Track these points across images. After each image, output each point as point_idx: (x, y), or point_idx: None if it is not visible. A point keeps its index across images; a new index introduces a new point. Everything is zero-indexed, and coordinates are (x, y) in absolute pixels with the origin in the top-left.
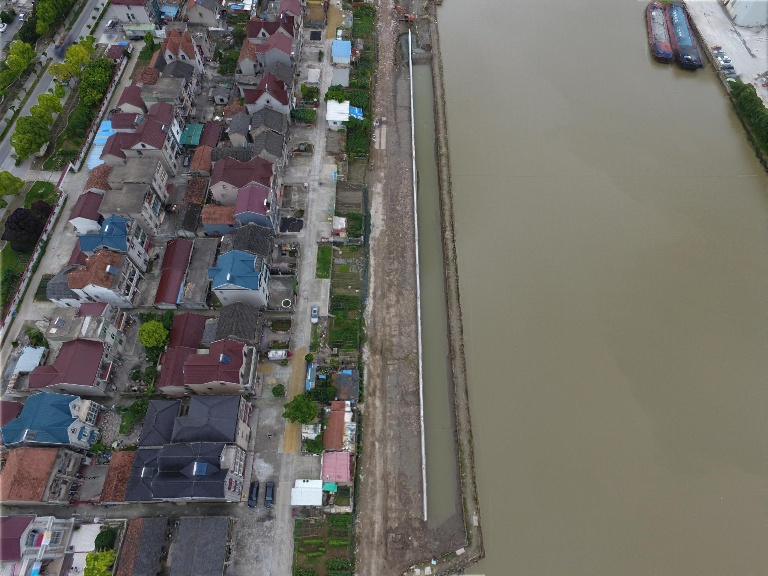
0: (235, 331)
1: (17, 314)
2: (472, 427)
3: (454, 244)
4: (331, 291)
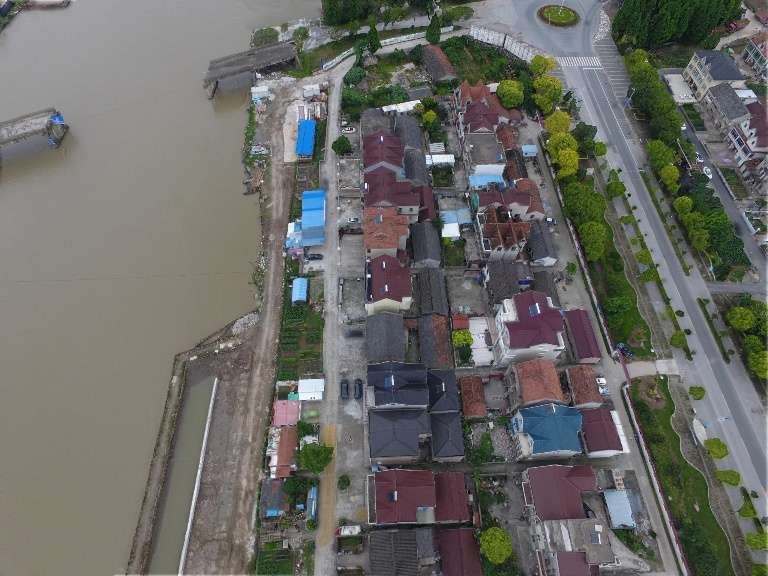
0: (391, 540)
1: None
2: None
3: None
4: None
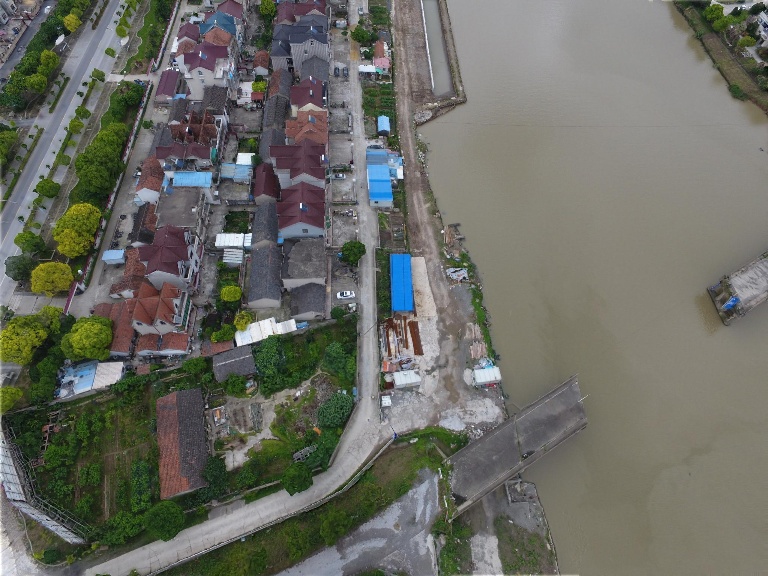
0: None
1: (179, 10)
2: (458, 60)
3: None
4: (369, 5)
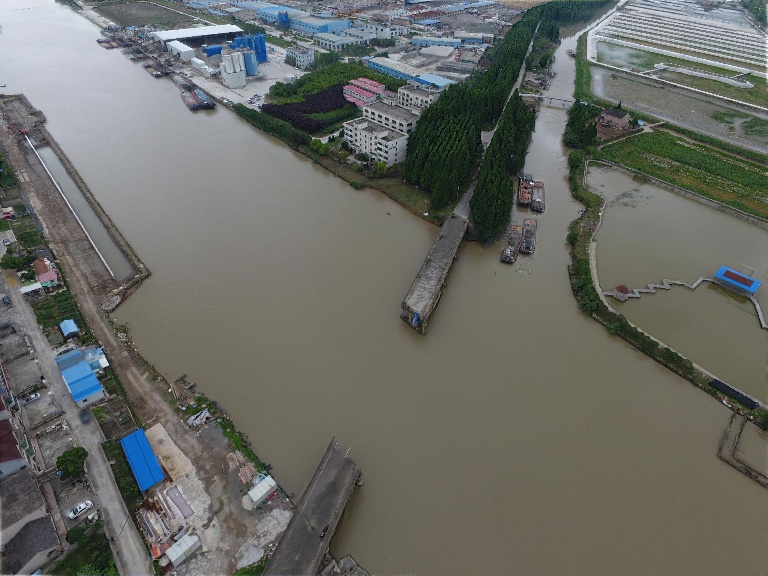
0: None
1: None
2: (130, 245)
3: (93, 197)
4: (15, 234)
